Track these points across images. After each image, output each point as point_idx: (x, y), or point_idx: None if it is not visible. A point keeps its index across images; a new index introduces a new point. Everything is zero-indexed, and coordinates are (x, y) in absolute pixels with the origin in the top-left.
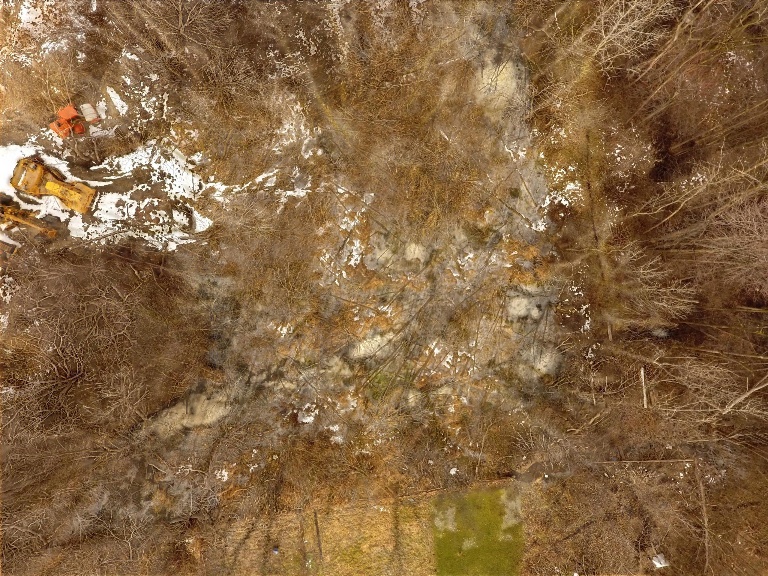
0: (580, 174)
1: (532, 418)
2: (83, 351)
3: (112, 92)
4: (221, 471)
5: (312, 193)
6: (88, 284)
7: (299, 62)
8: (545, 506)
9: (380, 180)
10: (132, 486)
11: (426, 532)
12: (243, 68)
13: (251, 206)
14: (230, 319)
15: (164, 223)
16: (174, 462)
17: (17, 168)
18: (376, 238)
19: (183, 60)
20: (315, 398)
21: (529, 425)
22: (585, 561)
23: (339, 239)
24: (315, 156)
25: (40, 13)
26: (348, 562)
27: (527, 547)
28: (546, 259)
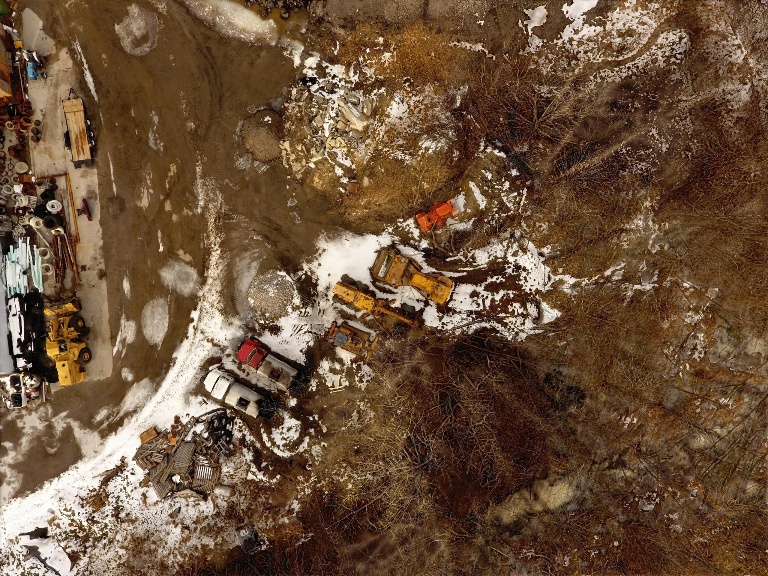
0: None
1: None
2: (435, 438)
3: (474, 187)
4: None
5: (659, 287)
6: (440, 372)
7: (651, 159)
8: None
9: (727, 276)
10: (475, 569)
11: None
12: (595, 163)
13: (598, 298)
14: (574, 408)
15: (519, 315)
16: (517, 546)
17: (378, 259)
18: (719, 332)
19: (536, 154)
20: (656, 487)
21: None
22: None
23: (683, 332)
24: (664, 251)
25: (406, 108)
26: None
27: None
28: None
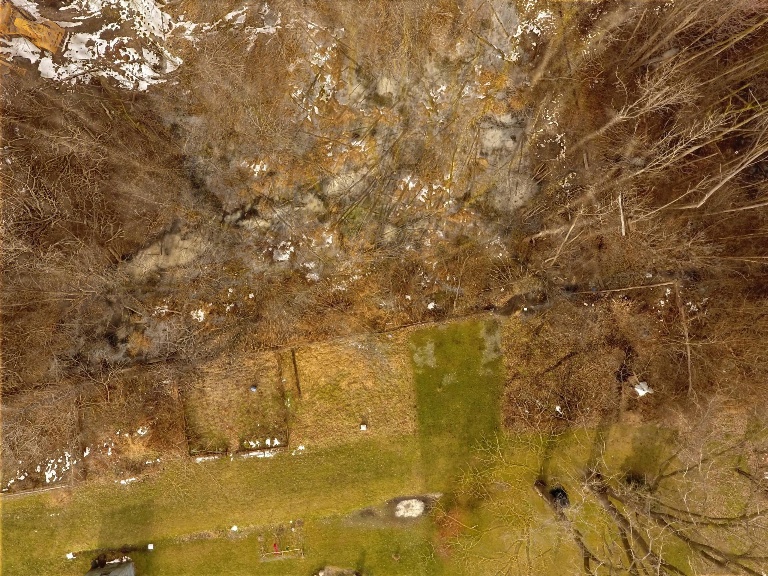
0: (551, 2)
1: (509, 250)
2: (56, 192)
3: None
4: (197, 311)
5: (282, 29)
6: (60, 125)
7: None
8: (525, 339)
9: (350, 13)
10: (108, 329)
11: (405, 368)
12: None
13: (221, 45)
14: (203, 159)
15: (134, 61)
16: (150, 303)
17: None
18: (347, 73)
19: None
20: (290, 236)
21: (506, 257)
22: (567, 393)
23: (310, 75)
24: None
25: None
26: (327, 400)
27: (508, 381)
28: (519, 89)
